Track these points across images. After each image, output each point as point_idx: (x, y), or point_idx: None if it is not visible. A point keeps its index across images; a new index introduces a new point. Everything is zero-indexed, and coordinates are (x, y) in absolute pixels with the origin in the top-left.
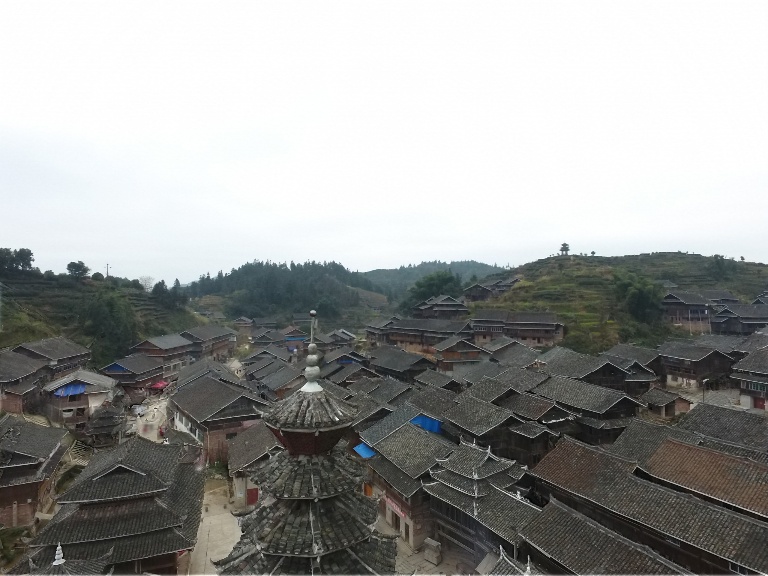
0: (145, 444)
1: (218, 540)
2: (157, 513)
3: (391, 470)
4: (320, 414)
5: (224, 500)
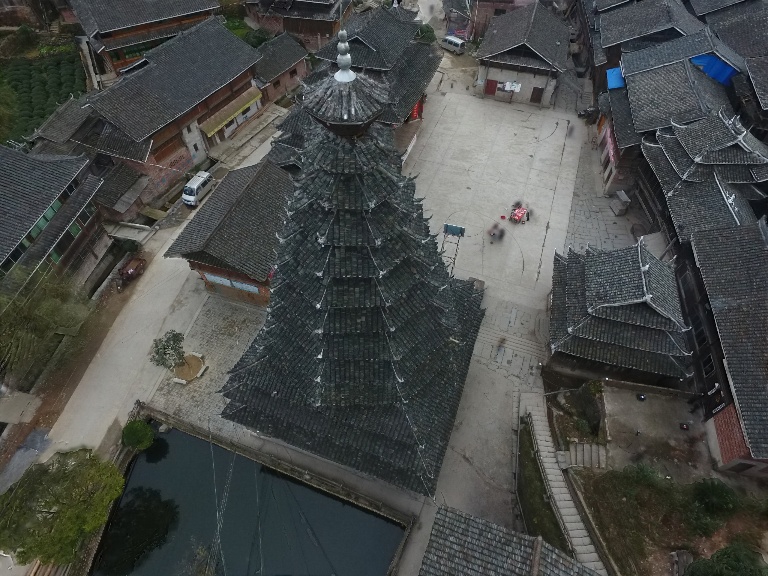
0: (386, 16)
1: (449, 117)
2: None
3: (625, 112)
4: (335, 107)
5: (470, 81)
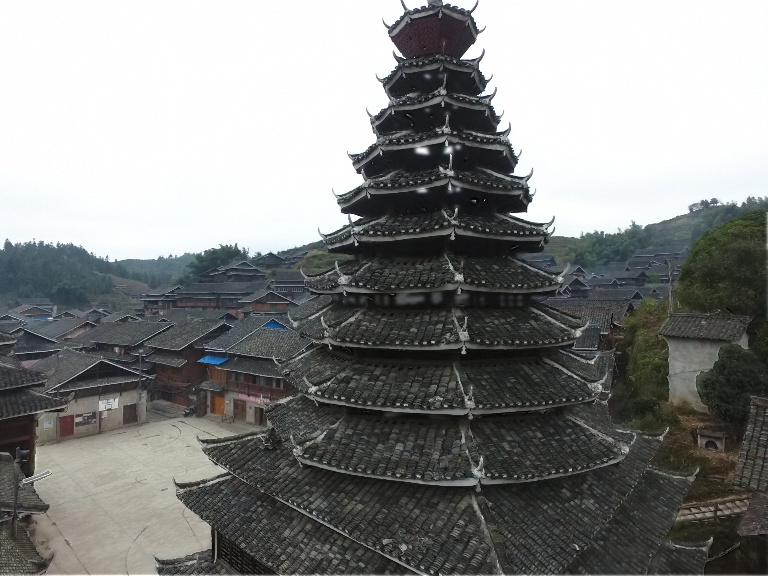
0: None
1: None
2: (1, 373)
3: (255, 365)
4: None
5: None
